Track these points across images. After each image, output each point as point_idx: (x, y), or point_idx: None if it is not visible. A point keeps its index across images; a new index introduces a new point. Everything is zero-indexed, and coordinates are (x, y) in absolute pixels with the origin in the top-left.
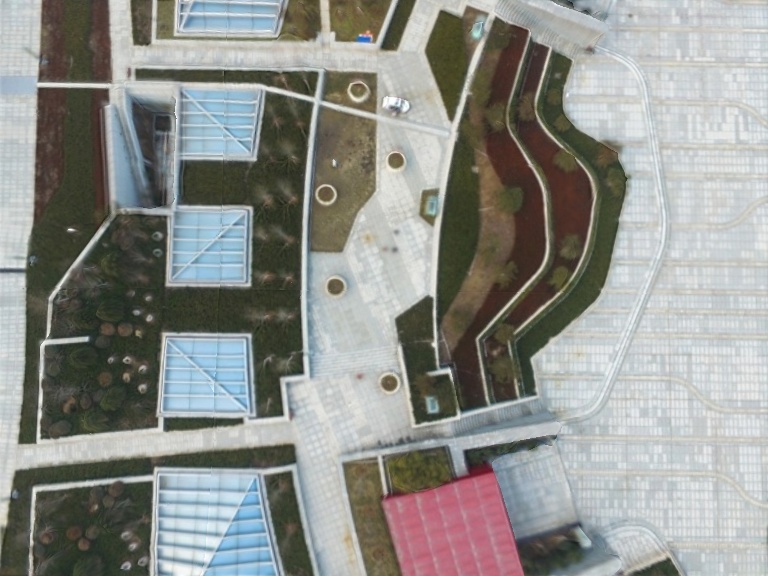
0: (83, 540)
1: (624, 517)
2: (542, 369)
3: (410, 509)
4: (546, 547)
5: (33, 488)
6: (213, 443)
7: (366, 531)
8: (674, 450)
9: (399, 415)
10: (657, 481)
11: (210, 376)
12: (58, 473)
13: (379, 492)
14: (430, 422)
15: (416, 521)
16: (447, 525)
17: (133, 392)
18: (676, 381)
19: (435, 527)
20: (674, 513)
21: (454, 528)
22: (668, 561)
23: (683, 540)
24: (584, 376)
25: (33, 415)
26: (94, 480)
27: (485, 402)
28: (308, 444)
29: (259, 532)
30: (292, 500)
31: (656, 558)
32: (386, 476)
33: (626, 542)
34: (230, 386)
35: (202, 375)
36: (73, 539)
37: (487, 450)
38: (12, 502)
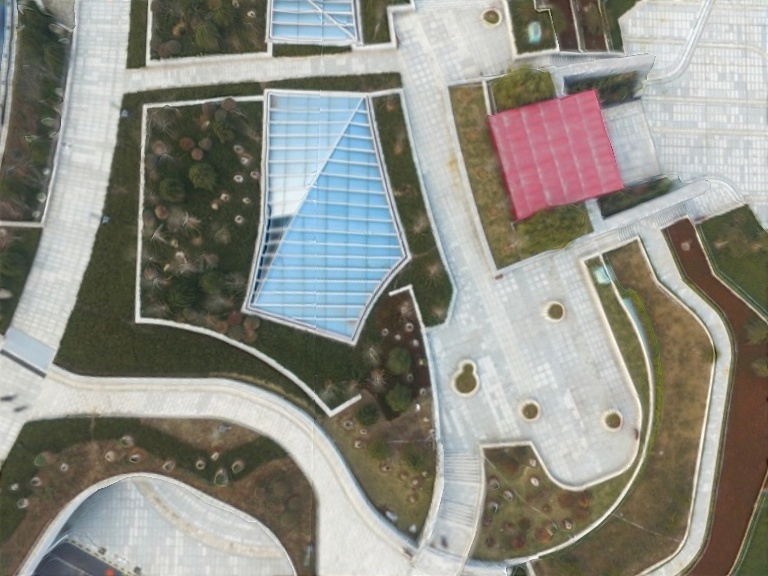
0: (196, 150)
1: (704, 172)
2: (628, 32)
3: (516, 123)
4: (634, 189)
5: (143, 106)
6: (321, 69)
7: (471, 152)
8: (750, 112)
9: (500, 48)
10: (734, 140)
11: (318, 6)
12: (168, 94)
13: (483, 115)
14: (531, 53)
15: (521, 134)
16: (551, 138)
17: (243, 16)
18: (751, 49)
19: (539, 140)
20: (750, 169)
21: (557, 141)
22: (746, 206)
23: (758, 194)
24: (667, 40)
25: (142, 39)
26: (205, 99)
27: (578, 50)
28: (413, 73)
29: (368, 149)
30: (400, 119)
31: (734, 206)
32: (490, 99)
33: (706, 193)
34: (338, 15)
35: (310, 4)
36: (186, 149)
37: (583, 85)
38: (121, 122)
